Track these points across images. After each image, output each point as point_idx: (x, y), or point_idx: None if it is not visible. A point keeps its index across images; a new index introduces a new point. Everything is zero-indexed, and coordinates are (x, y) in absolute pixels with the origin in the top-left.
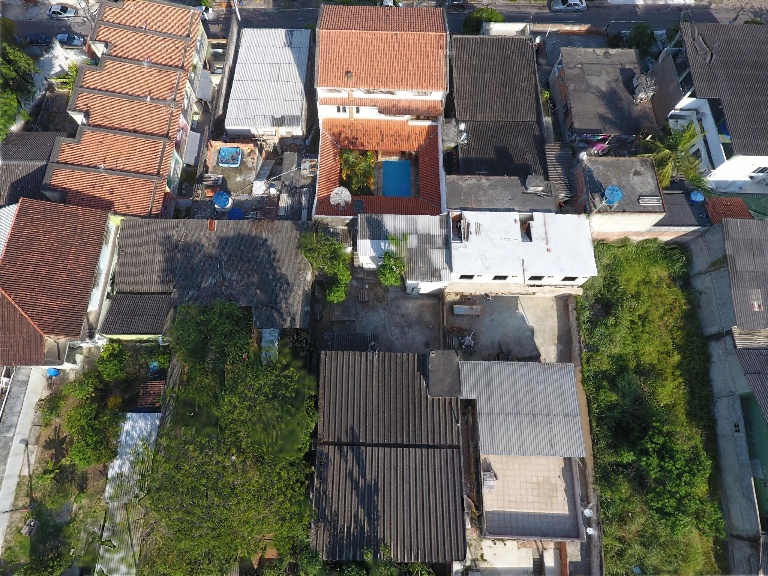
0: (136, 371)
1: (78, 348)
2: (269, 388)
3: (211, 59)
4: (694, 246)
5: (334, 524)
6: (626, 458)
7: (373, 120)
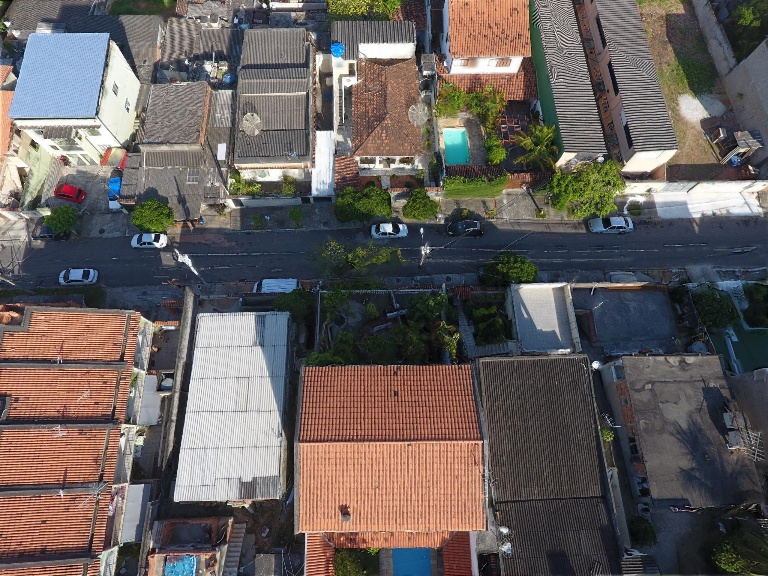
0: None
1: None
2: None
3: (160, 341)
4: None
5: None
6: None
7: None
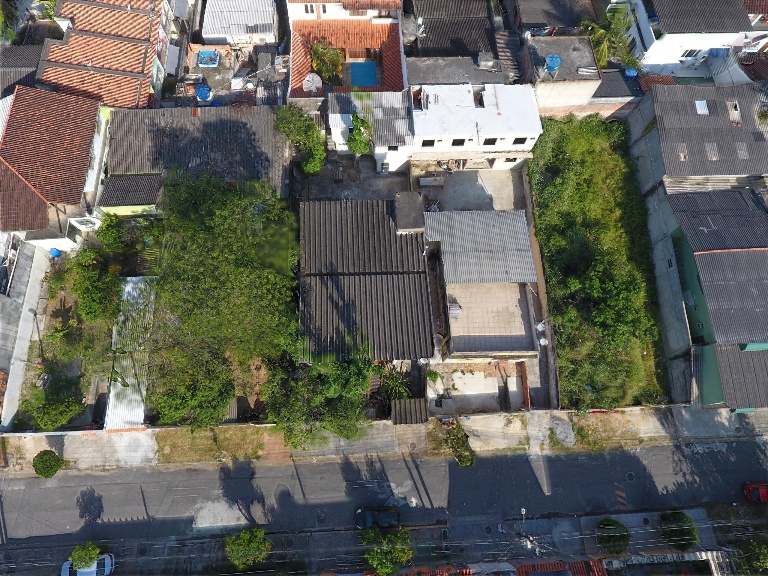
0: (133, 245)
1: (77, 231)
2: (254, 209)
3: None
4: (631, 119)
5: (318, 336)
6: (573, 285)
7: (339, 20)
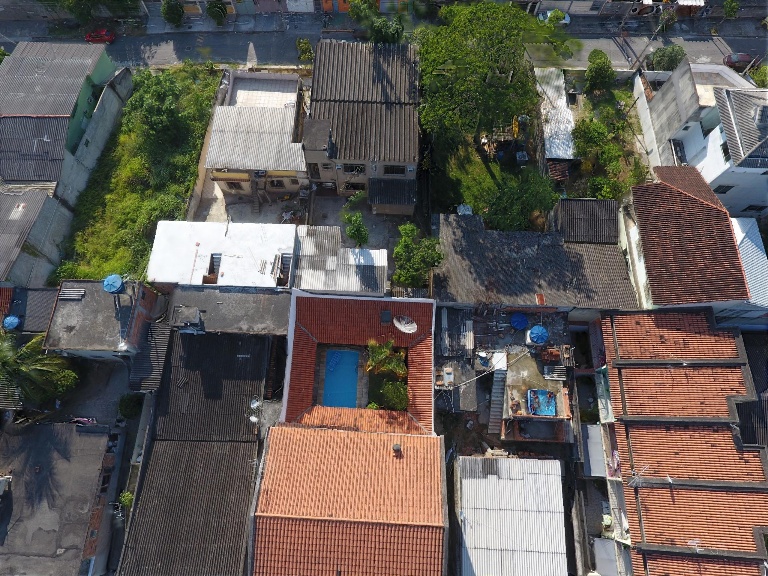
0: None
1: None
2: None
3: None
4: None
5: (404, 61)
6: None
7: None
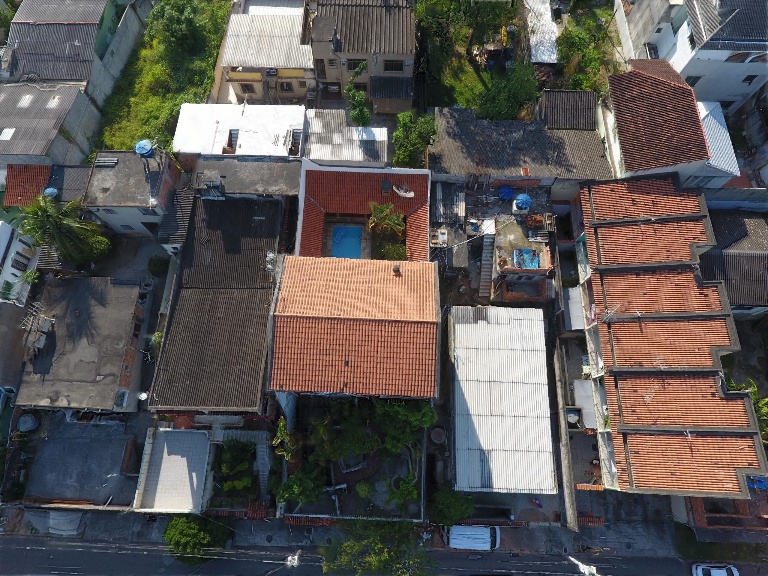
0: None
1: None
2: None
3: None
4: None
5: None
6: None
7: None
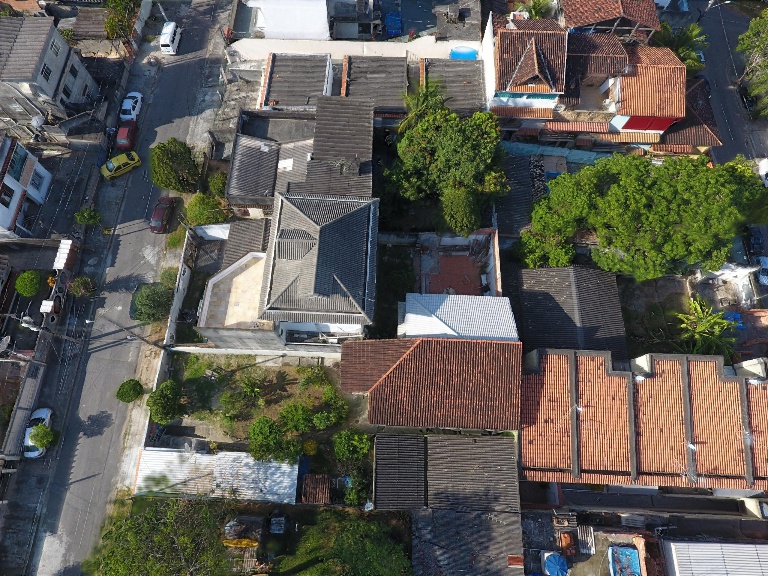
0: None
1: None
2: None
3: None
4: None
5: None
6: None
7: None
